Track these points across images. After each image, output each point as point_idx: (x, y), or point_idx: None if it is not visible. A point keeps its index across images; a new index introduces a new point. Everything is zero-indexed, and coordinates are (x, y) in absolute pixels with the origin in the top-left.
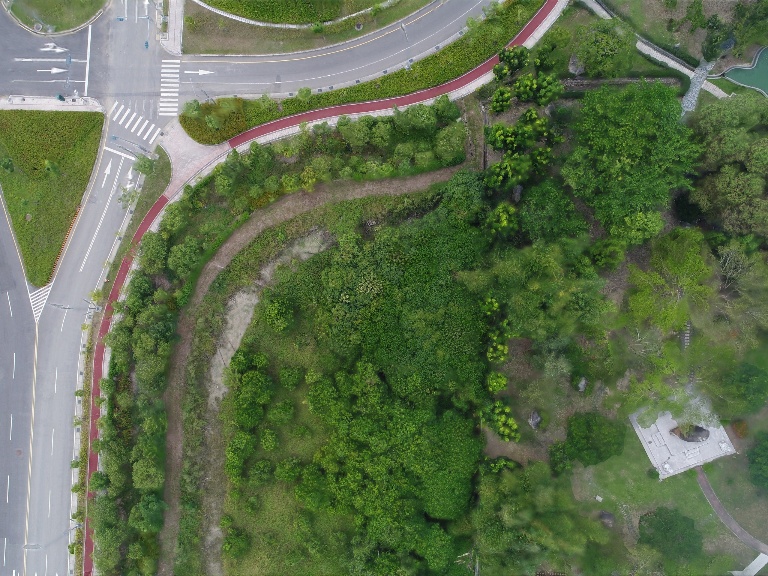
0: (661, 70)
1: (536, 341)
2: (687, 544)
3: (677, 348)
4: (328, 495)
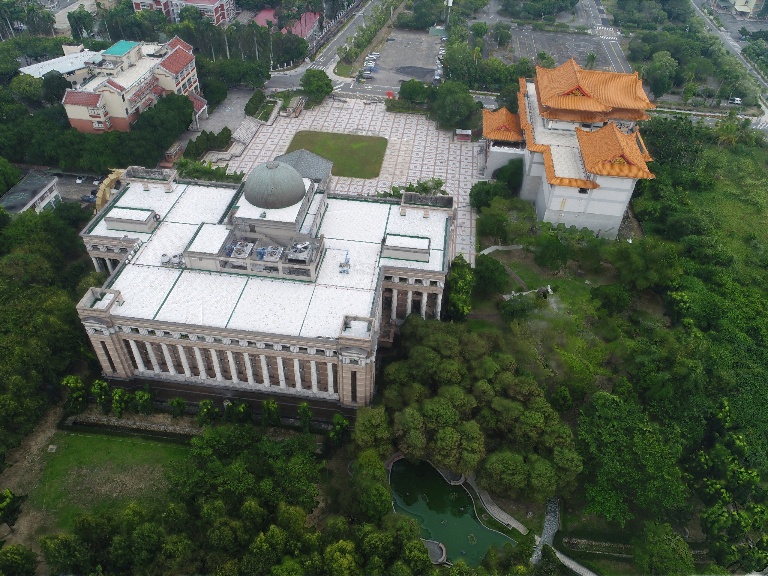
0: (586, 556)
1: None
2: (552, 245)
3: (565, 332)
4: (764, 297)
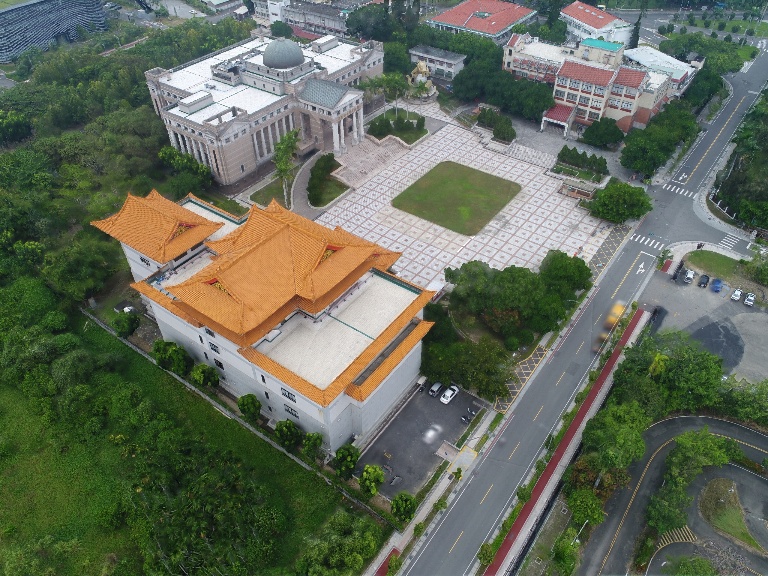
0: None
1: (29, 230)
2: None
3: None
4: None
